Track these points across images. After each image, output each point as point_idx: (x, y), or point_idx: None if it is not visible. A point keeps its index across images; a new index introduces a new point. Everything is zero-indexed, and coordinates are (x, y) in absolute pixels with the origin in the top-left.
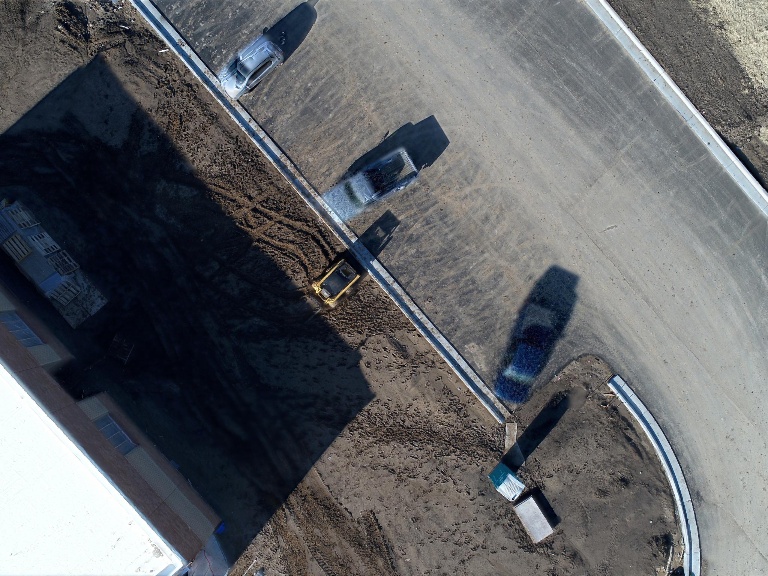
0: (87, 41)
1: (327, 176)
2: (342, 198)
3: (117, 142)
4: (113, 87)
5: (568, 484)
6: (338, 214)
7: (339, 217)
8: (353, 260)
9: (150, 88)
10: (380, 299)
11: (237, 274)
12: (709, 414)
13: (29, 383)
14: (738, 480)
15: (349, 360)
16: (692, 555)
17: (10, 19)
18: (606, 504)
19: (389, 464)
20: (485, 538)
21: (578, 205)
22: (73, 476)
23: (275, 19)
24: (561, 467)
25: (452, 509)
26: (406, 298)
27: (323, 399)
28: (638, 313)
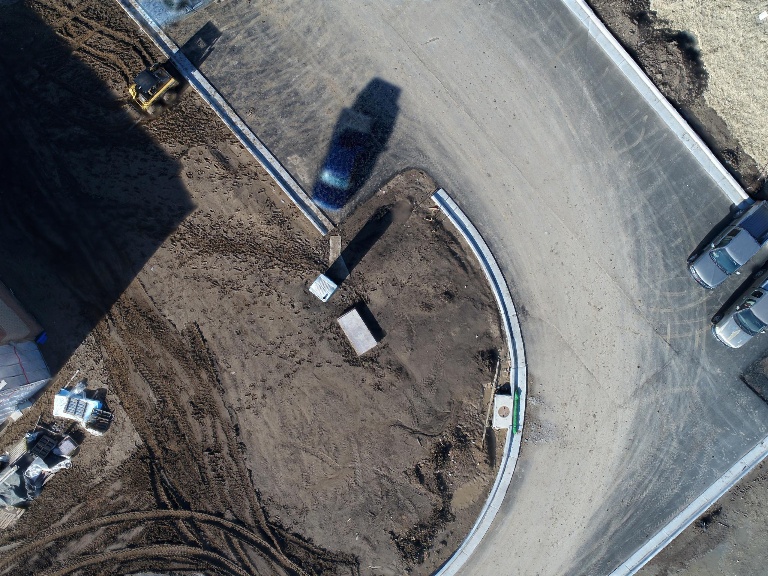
0: None
1: None
2: (163, 9)
3: None
4: None
5: (393, 297)
6: (159, 25)
7: (160, 27)
8: (175, 71)
9: None
10: (202, 110)
11: (57, 83)
12: (533, 228)
13: None
14: (563, 294)
15: (171, 170)
16: (518, 369)
17: None
18: (431, 318)
19: (212, 276)
20: (310, 351)
21: (400, 17)
22: None
23: None
24: (385, 280)
25: (277, 322)
26: (228, 109)
27: (145, 209)
28: (461, 126)
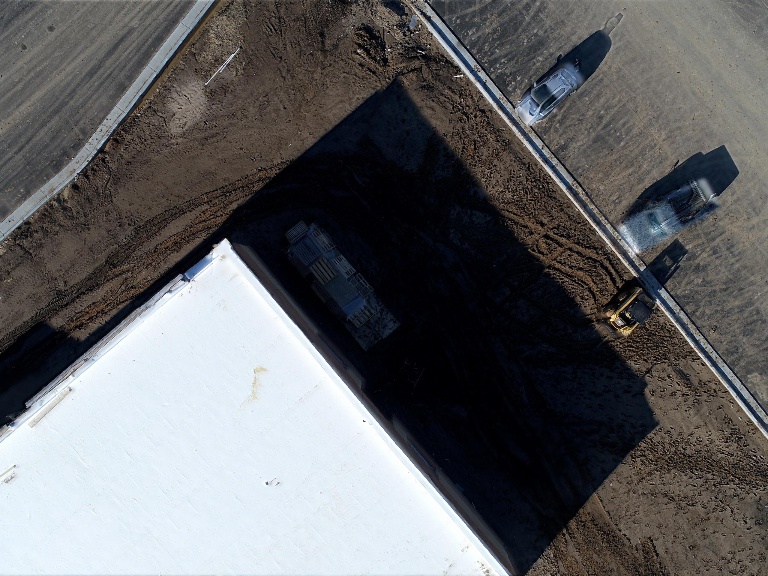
0: (385, 65)
1: (617, 204)
2: (631, 226)
3: (412, 166)
4: (410, 112)
5: None
6: (627, 242)
7: (628, 245)
8: None
9: (445, 113)
10: (665, 327)
11: (527, 300)
12: None
13: (373, 410)
14: None
15: (634, 388)
16: None
17: (310, 42)
18: None
19: (669, 492)
20: (760, 567)
21: None
22: (409, 502)
23: (569, 46)
24: None
25: (729, 538)
26: (692, 327)
27: (607, 426)
28: None
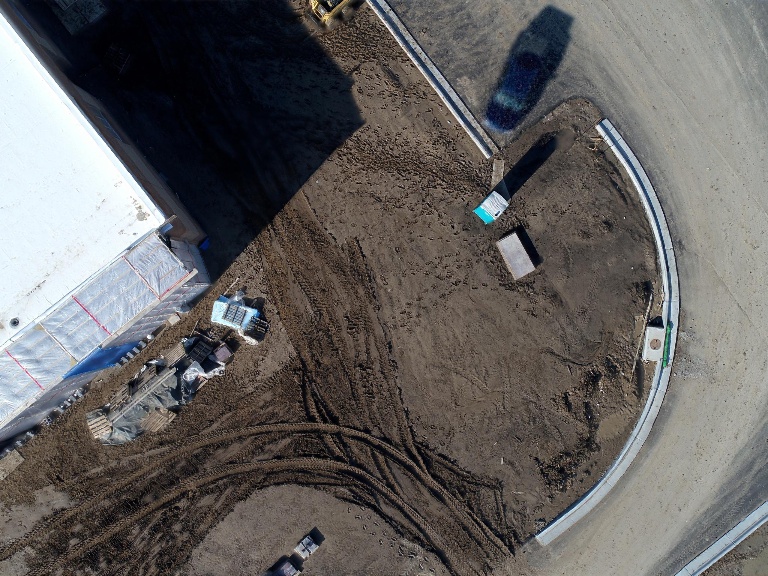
0: None
1: None
2: None
3: None
4: None
5: (552, 224)
6: None
7: None
8: None
9: None
10: (375, 27)
11: None
12: (695, 163)
13: (24, 34)
14: (720, 231)
15: (342, 84)
16: (671, 303)
17: None
18: (589, 247)
19: (376, 192)
20: (467, 273)
21: None
22: (62, 133)
23: None
24: (546, 207)
25: (436, 242)
26: (401, 27)
27: (314, 121)
28: (630, 57)
